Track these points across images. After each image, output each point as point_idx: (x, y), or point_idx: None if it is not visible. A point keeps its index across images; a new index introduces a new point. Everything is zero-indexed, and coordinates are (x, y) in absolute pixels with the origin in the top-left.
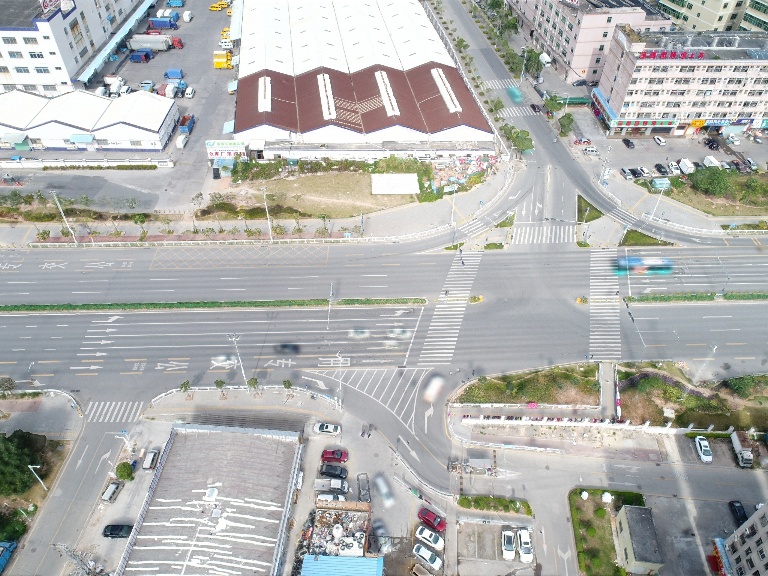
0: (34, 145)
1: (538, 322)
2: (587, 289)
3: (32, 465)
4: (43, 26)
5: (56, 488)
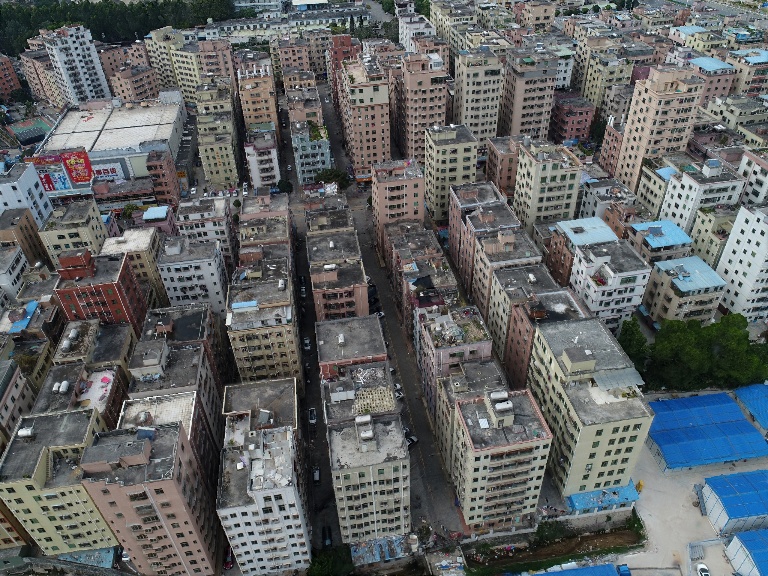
0: None
1: None
2: None
3: (633, 4)
4: None
5: None
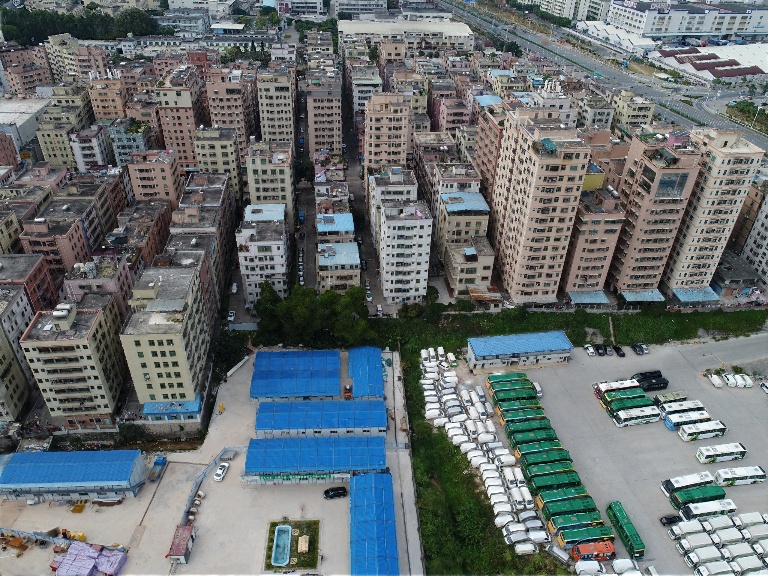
0: (608, 41)
1: None
2: None
3: None
4: (647, 12)
5: None
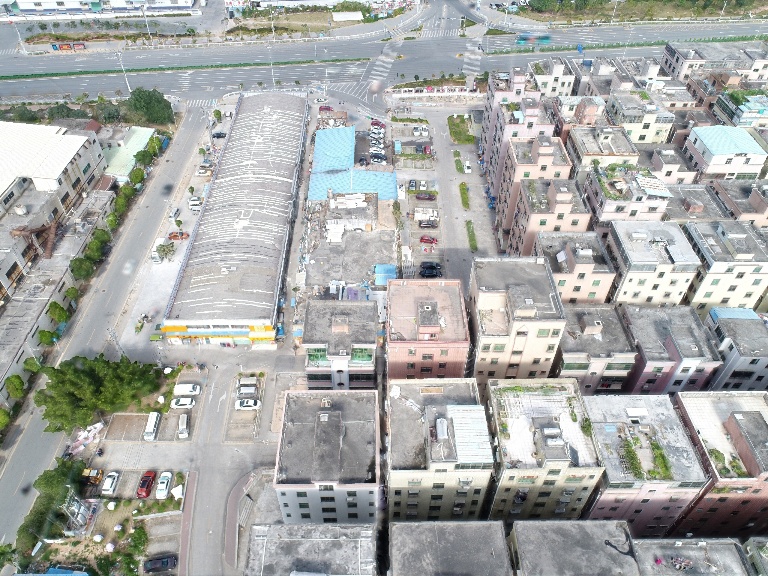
0: (105, 6)
1: (435, 64)
2: (463, 52)
3: None
4: None
5: (181, 127)
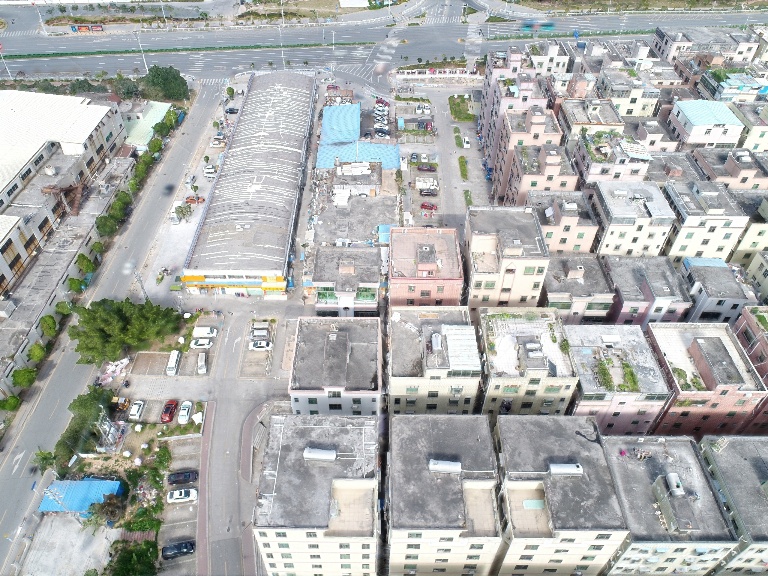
0: None
1: (437, 48)
2: (465, 37)
3: None
4: None
5: (195, 104)
